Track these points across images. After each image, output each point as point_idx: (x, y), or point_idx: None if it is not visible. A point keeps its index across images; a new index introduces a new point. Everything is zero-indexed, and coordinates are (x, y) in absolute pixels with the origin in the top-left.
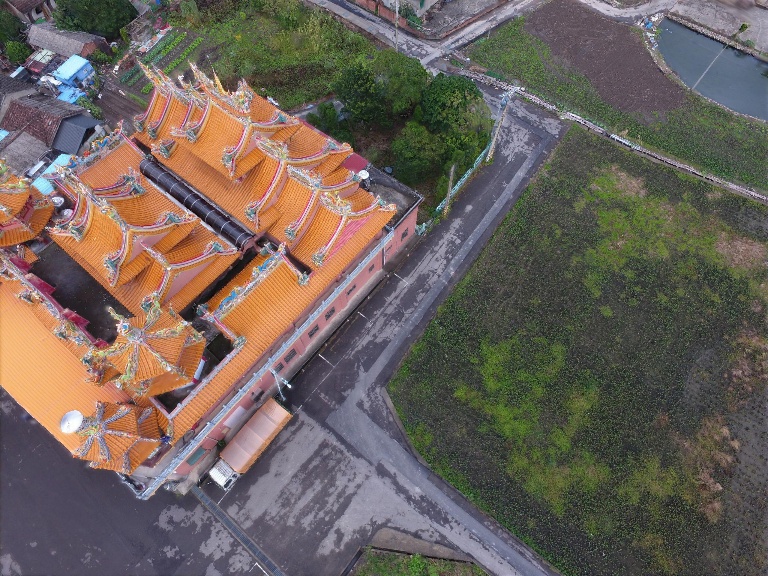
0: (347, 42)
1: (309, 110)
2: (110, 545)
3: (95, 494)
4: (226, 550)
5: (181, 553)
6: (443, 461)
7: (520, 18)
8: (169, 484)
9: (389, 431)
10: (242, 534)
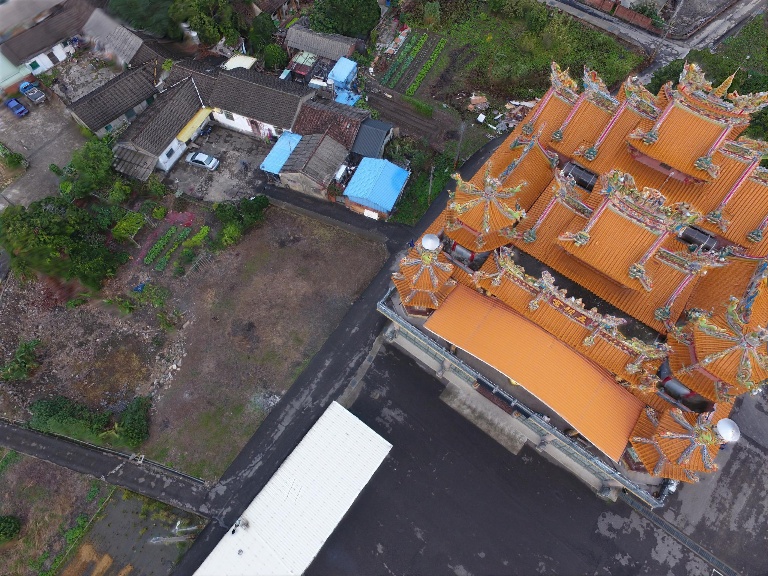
0: (598, 42)
1: None
2: (560, 554)
3: (524, 502)
4: (678, 557)
5: (635, 561)
6: None
7: (760, 17)
8: (608, 491)
9: None
10: (688, 540)
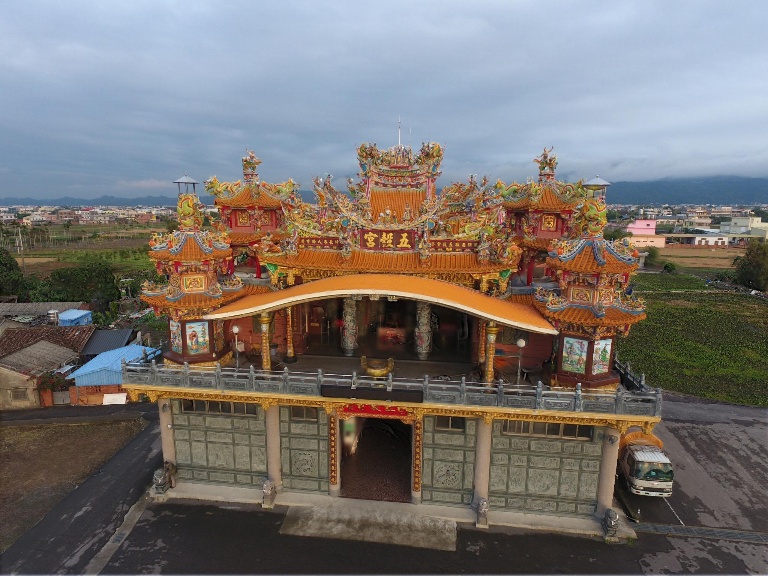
0: None
1: None
2: None
3: None
4: None
5: None
6: (761, 401)
7: None
8: None
9: (696, 402)
10: (759, 535)
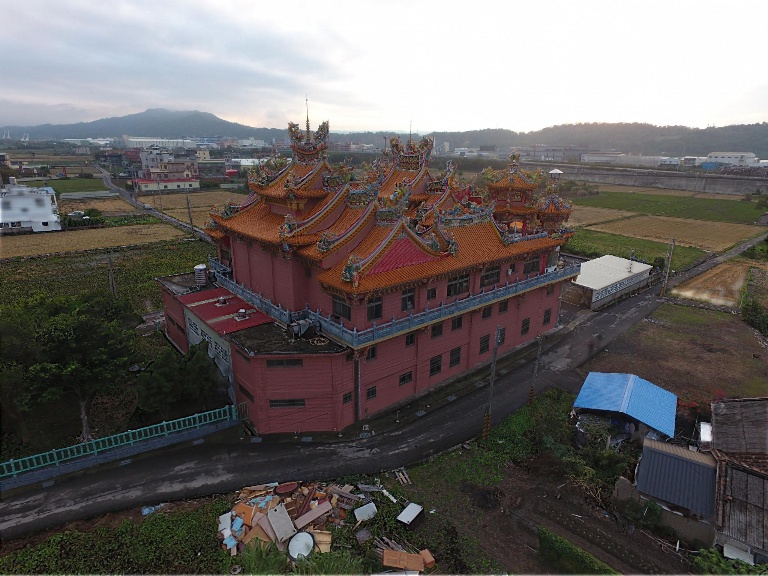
0: None
1: (161, 493)
2: None
3: None
4: None
5: None
6: None
7: None
8: None
9: None
10: None
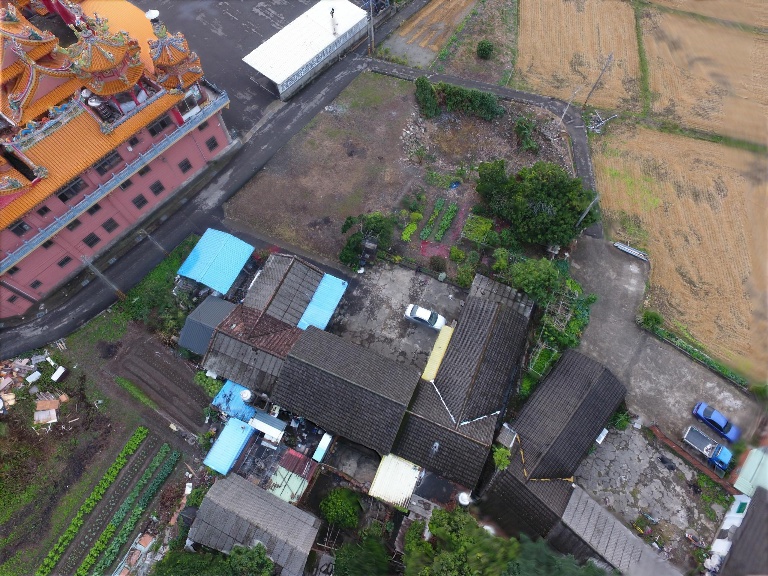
0: None
1: None
2: None
3: None
4: None
5: None
6: None
7: None
8: None
9: None
10: None
